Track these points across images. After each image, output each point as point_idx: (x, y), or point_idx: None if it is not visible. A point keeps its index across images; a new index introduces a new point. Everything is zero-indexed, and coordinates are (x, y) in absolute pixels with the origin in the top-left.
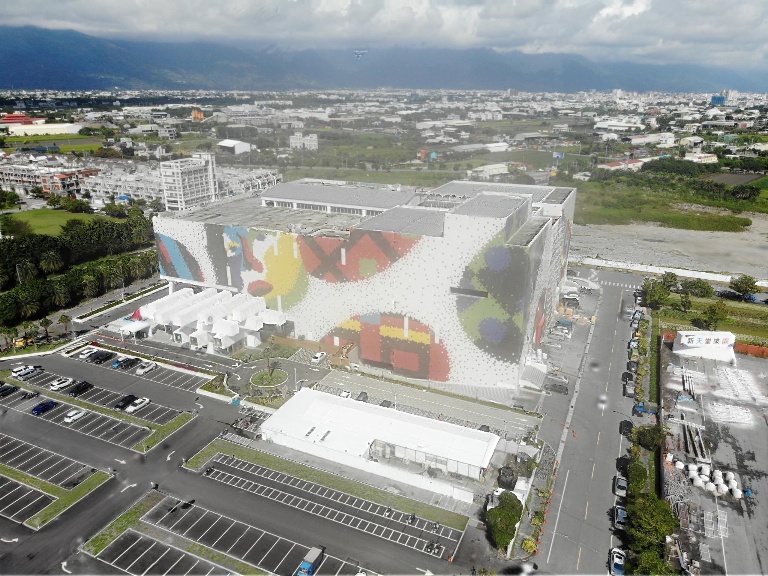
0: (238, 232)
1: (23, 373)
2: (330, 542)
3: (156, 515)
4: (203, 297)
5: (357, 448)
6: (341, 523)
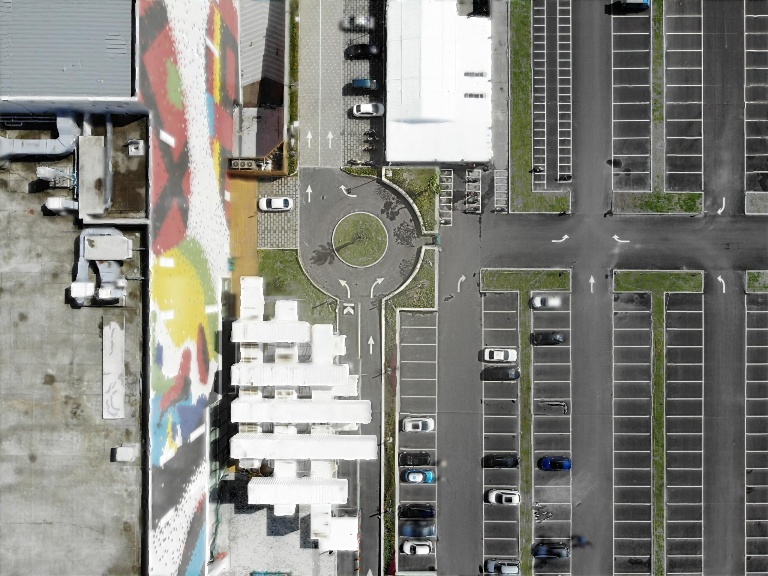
0: (158, 424)
1: (516, 569)
2: (598, 5)
3: (641, 182)
4: (272, 440)
5: (481, 29)
6: (572, 7)
